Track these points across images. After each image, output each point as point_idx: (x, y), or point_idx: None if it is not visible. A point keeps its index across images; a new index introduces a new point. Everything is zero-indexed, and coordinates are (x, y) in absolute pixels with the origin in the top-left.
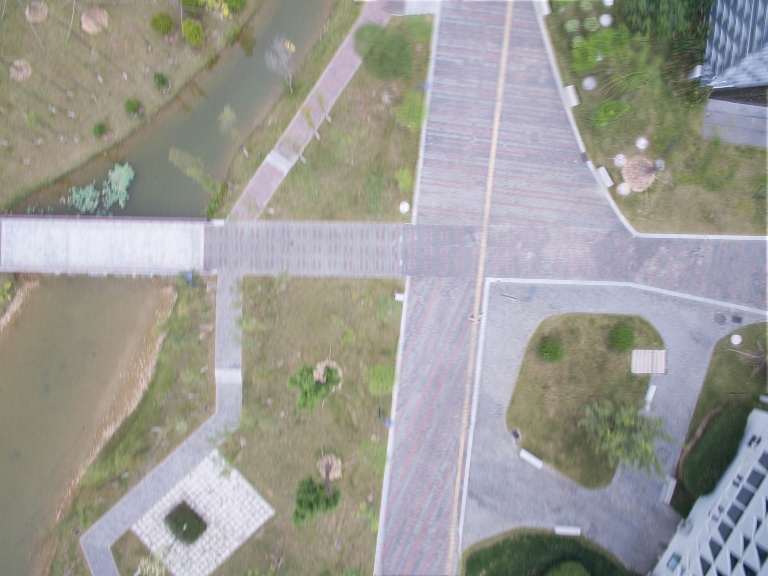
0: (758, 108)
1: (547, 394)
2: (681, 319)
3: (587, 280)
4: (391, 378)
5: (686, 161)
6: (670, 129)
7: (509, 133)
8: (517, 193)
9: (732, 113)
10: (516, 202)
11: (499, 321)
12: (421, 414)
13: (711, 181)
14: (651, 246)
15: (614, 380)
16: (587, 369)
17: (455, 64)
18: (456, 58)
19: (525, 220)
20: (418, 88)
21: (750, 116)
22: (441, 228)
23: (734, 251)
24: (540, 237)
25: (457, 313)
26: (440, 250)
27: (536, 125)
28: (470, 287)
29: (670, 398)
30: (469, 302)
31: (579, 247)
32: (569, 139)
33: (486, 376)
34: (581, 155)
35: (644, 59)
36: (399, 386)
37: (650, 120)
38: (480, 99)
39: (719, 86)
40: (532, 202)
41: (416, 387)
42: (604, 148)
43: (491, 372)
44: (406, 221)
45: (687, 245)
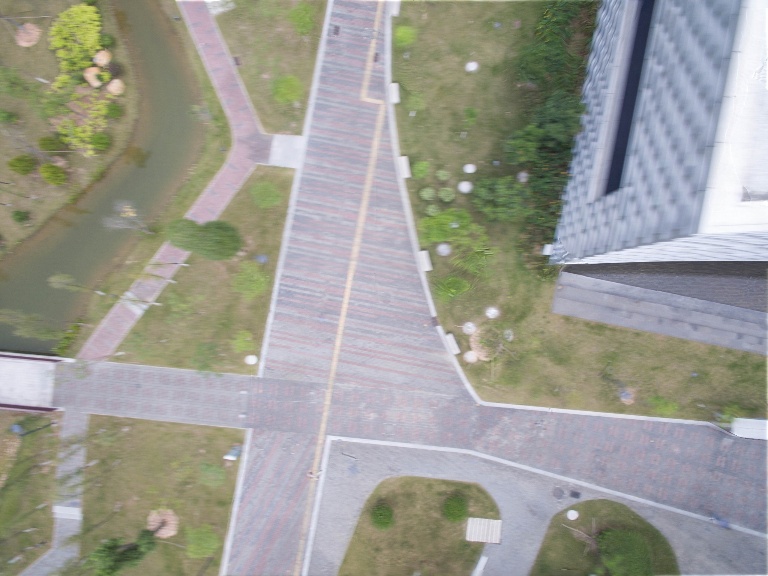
0: (612, 284)
1: (379, 557)
2: (519, 490)
3: (428, 445)
4: (226, 529)
5: (535, 333)
6: (521, 300)
7: (361, 292)
8: (365, 353)
9: (585, 288)
10: (363, 362)
11: (337, 479)
12: (253, 566)
13: (558, 355)
14: (494, 415)
15: (447, 547)
16: (420, 535)
17: (313, 220)
18: (315, 214)
19: (371, 381)
20: (274, 242)
21: (603, 292)
22: (287, 383)
23: (577, 426)
24: (384, 398)
25: (296, 468)
26: (284, 405)
27: (389, 286)
28: (311, 443)
29: (502, 569)
30: (309, 458)
31: (422, 411)
32: (421, 302)
33: (321, 533)
34: (431, 319)
35: (499, 229)
36: (233, 537)
37: (502, 290)
38: (335, 257)
39: (571, 262)
40: (379, 363)
41: (250, 539)
42: (455, 314)
43: (326, 530)
44: (253, 373)
45: (530, 417)
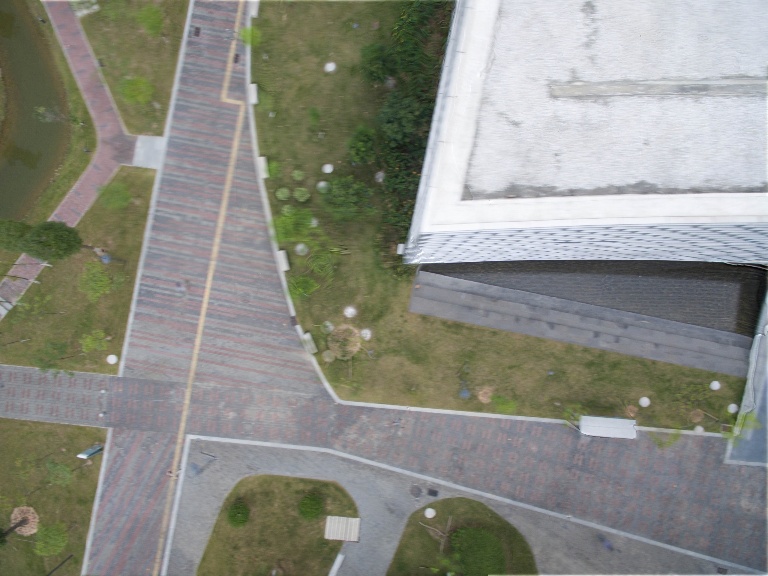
0: (470, 283)
1: (237, 555)
2: (377, 489)
3: (286, 443)
4: (86, 527)
5: (392, 332)
6: (378, 300)
7: (221, 292)
8: (224, 352)
9: (443, 287)
10: (222, 361)
11: (197, 478)
12: (113, 565)
13: (416, 354)
14: (353, 414)
15: (304, 546)
16: (278, 533)
17: (173, 220)
18: (175, 214)
19: (230, 380)
20: (134, 242)
21: (461, 291)
22: (146, 382)
23: (435, 424)
24: (243, 398)
25: (156, 467)
26: (143, 404)
27: (248, 286)
28: (171, 442)
29: (360, 566)
30: (169, 457)
31: (281, 410)
32: (280, 302)
33: (180, 532)
34: (291, 319)
35: (357, 229)
36: (93, 536)
37: (359, 289)
38: (195, 257)
39: (427, 261)
40: (238, 362)
41: (110, 538)
42: (313, 313)
43: (185, 528)
44: (113, 373)
45: (388, 415)
